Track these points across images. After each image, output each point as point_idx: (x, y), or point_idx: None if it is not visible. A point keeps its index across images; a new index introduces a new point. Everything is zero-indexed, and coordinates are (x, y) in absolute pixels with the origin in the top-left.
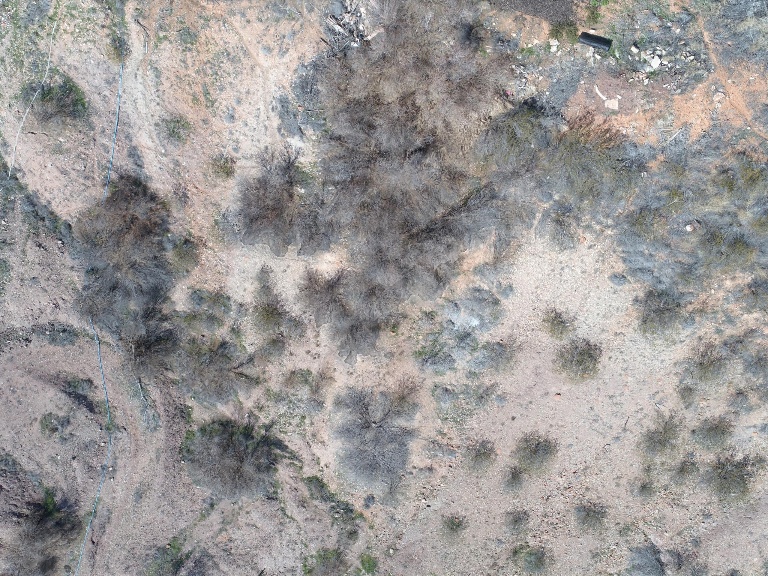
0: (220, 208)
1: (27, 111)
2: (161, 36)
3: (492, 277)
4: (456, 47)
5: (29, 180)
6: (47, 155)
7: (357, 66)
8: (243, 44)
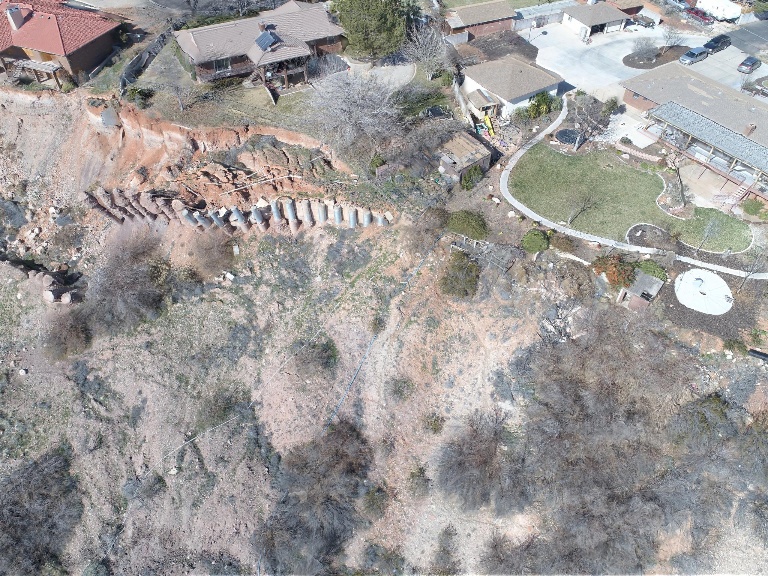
0: (419, 462)
1: (291, 357)
2: (412, 320)
3: (692, 571)
4: (646, 349)
5: (264, 412)
6: (292, 391)
7: (563, 355)
8: (474, 331)
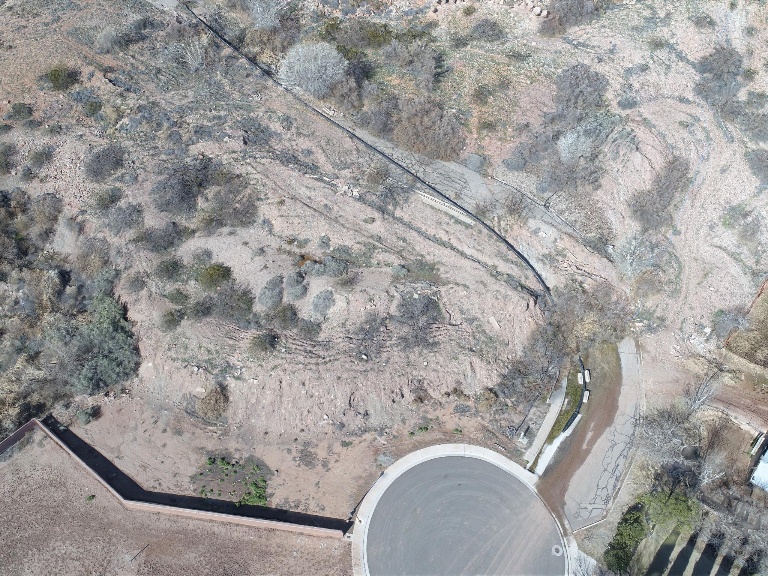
0: (766, 60)
1: (690, 22)
2: (751, 2)
3: None
4: None
5: (680, 47)
6: (696, 34)
7: None
8: None
